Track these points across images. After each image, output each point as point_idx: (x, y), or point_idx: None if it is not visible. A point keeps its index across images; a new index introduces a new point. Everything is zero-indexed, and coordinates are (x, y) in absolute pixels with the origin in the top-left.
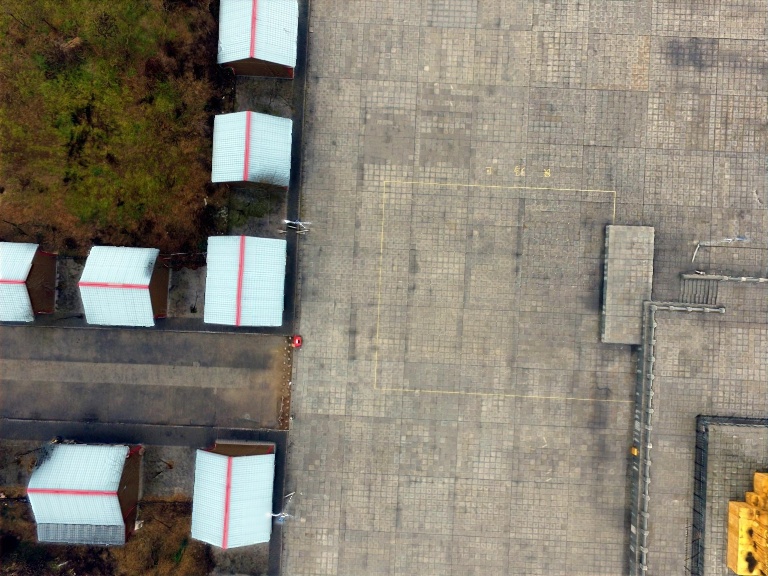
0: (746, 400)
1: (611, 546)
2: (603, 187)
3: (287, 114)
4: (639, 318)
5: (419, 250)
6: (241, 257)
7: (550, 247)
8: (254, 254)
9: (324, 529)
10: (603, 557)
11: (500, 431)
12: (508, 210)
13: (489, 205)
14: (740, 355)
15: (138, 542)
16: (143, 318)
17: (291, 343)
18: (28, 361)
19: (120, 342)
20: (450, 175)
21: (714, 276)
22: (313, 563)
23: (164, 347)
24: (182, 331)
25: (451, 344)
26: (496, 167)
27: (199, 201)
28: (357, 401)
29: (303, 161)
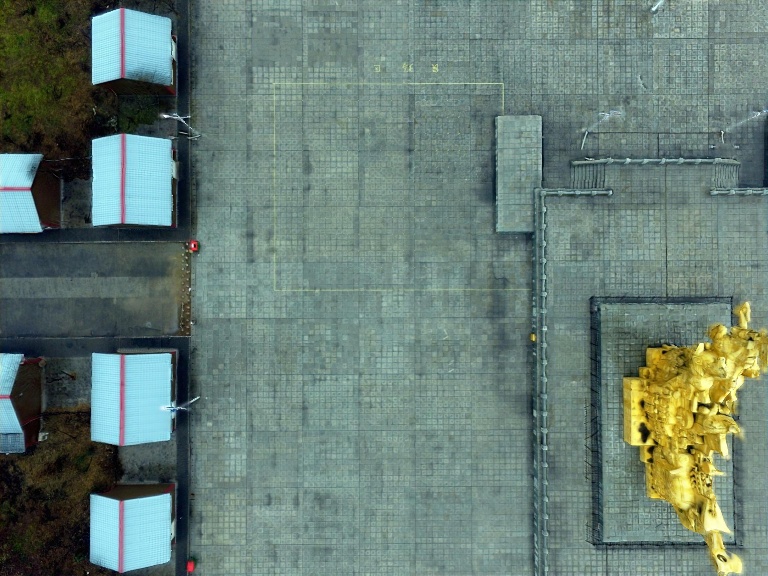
0: (637, 280)
1: (515, 432)
2: (491, 79)
3: (172, 20)
4: (531, 206)
5: (312, 151)
6: (123, 155)
7: (442, 141)
8: (137, 152)
9: (231, 432)
10: (508, 443)
11: (401, 326)
12: (398, 107)
13: (379, 103)
14: (630, 236)
15: (44, 454)
16: (29, 223)
17: (188, 249)
18: None
19: (15, 256)
20: (339, 74)
21: (601, 159)
22: (222, 466)
23: (60, 259)
24: (77, 242)
25: (348, 242)
26: (384, 64)
27: (88, 111)
28: (258, 304)
29: (191, 67)
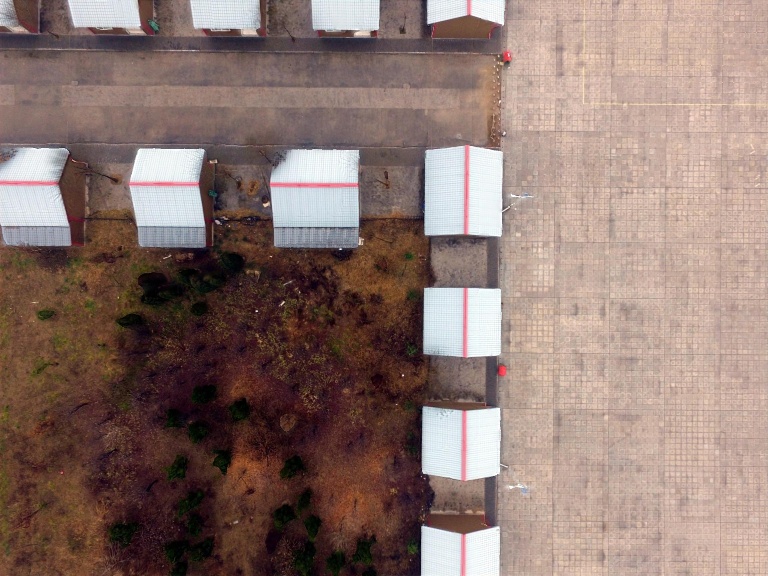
0: None
1: None
2: None
3: None
4: None
5: None
6: None
7: None
8: None
9: (539, 242)
10: None
11: (708, 140)
12: None
13: None
14: None
15: (360, 260)
16: (369, 19)
17: (499, 61)
18: (241, 88)
19: (331, 66)
20: None
21: None
22: (530, 276)
23: (374, 70)
24: (392, 52)
25: (657, 57)
26: None
27: None
28: (566, 116)
29: None
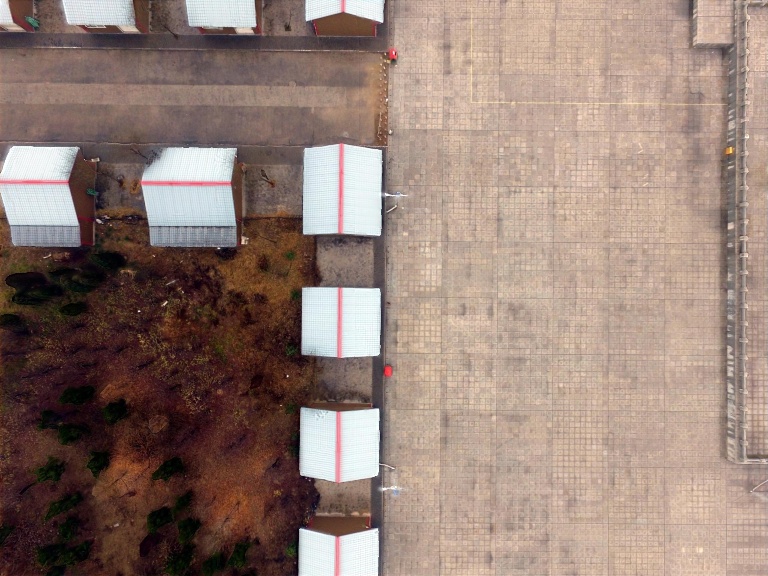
0: None
1: (708, 246)
2: None
3: None
4: (730, 17)
5: None
6: None
7: None
8: None
9: (427, 242)
10: (701, 257)
11: (596, 139)
12: None
13: None
14: None
15: (244, 259)
16: (246, 16)
17: (386, 59)
18: (124, 85)
19: (216, 64)
20: None
21: None
22: (417, 275)
23: (260, 68)
24: (277, 50)
25: (545, 55)
26: None
27: None
28: (454, 115)
29: None
